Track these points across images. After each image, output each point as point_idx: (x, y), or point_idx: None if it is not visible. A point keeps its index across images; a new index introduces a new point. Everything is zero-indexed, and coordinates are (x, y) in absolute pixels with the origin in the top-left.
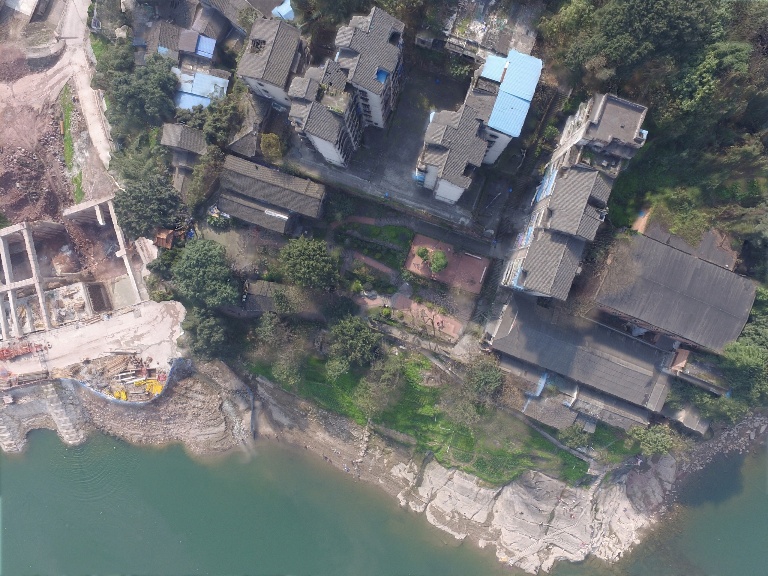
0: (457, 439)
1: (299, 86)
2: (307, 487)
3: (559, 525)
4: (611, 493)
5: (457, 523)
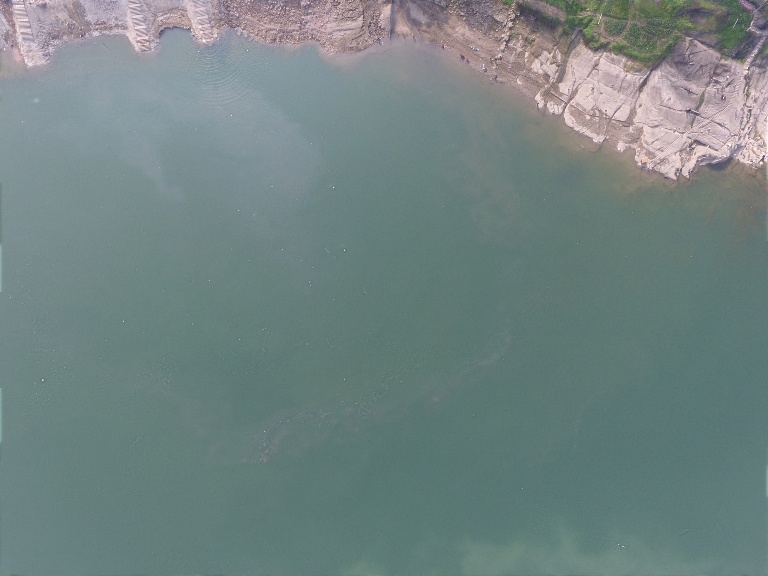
0: (612, 3)
1: None
2: (442, 89)
3: (707, 112)
4: (764, 77)
5: (597, 122)
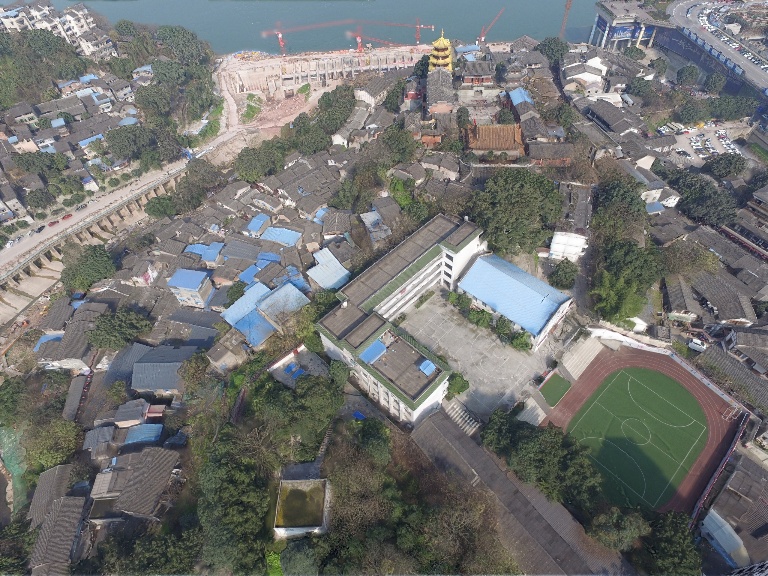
0: None
1: (77, 8)
2: None
3: None
4: None
5: None
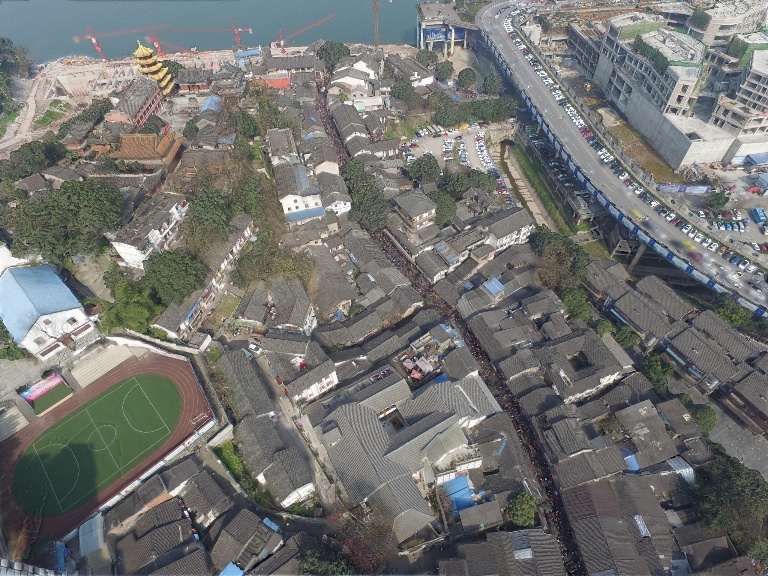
0: None
1: None
2: None
3: None
4: None
5: None
